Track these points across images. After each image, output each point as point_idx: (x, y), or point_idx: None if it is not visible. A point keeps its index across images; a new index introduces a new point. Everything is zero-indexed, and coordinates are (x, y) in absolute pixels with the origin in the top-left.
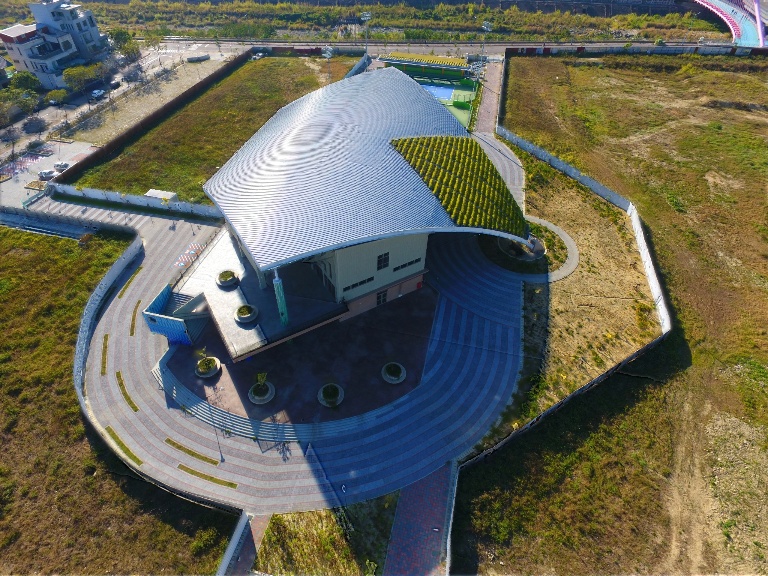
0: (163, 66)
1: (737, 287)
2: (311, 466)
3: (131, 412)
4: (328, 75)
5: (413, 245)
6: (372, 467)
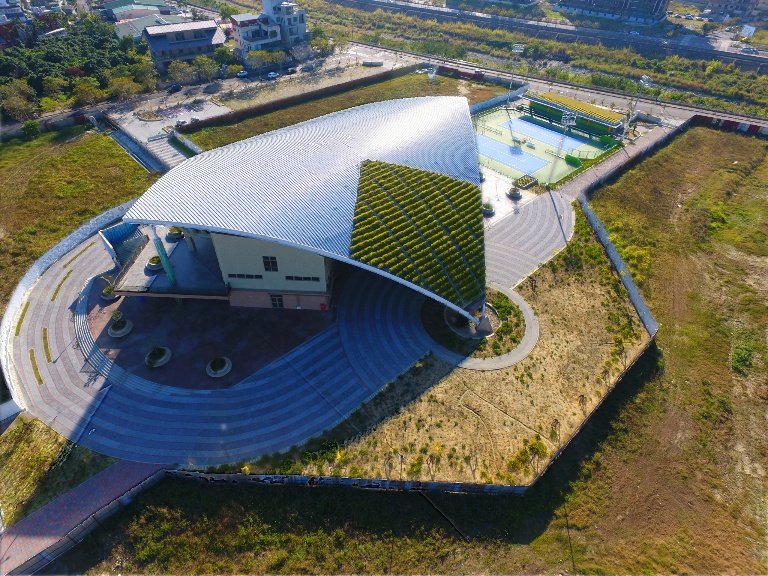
0: None
1: (715, 499)
2: (93, 401)
3: (49, 299)
4: (468, 100)
5: (306, 260)
6: (125, 429)
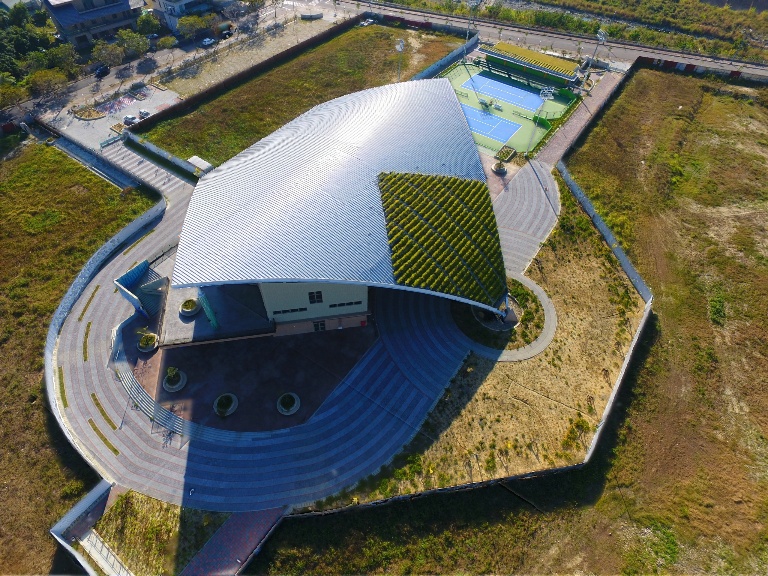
0: (276, 21)
1: (718, 439)
2: (179, 461)
3: (81, 360)
4: (423, 57)
5: (350, 289)
6: (223, 483)
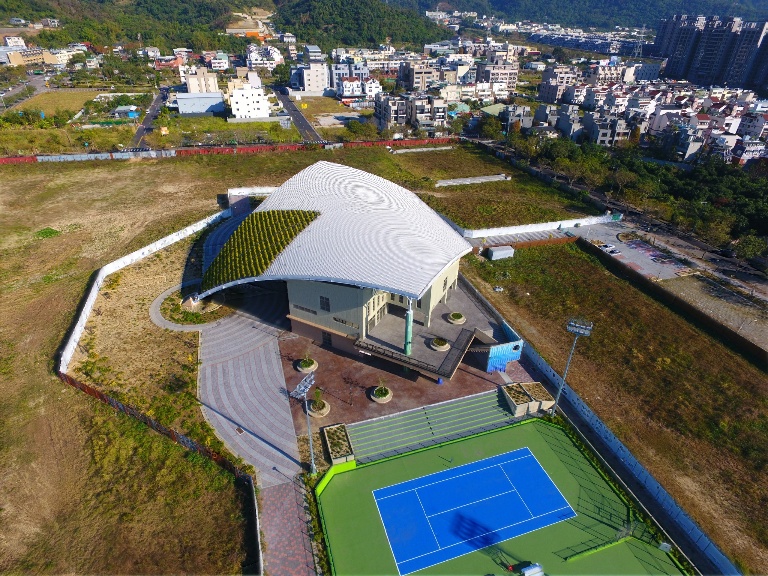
0: None
1: (2, 328)
2: None
3: None
4: None
5: None
6: None
